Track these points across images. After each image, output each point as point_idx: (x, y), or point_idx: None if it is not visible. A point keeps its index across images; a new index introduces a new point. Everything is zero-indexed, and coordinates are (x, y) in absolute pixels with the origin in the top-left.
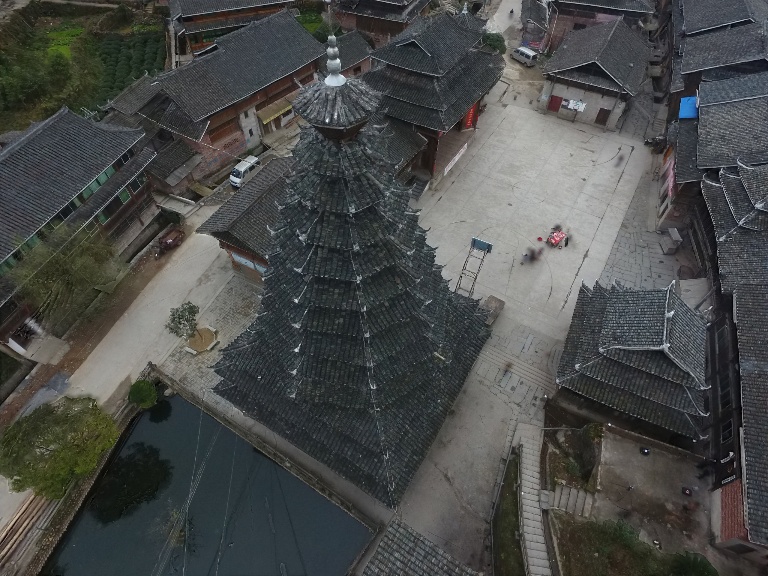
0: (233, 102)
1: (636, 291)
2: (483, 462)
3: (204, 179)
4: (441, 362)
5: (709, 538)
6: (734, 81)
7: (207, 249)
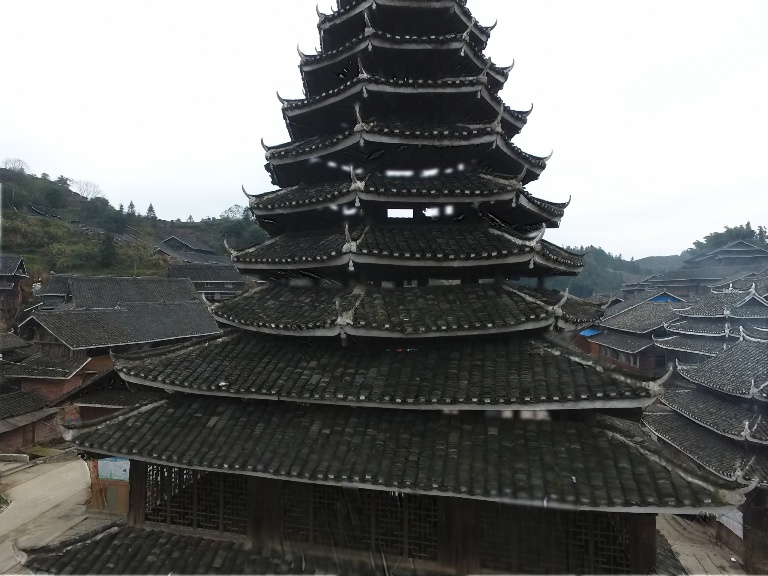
0: (129, 343)
1: (712, 358)
2: None
3: (51, 445)
4: (595, 308)
5: None
6: (609, 309)
7: (34, 501)
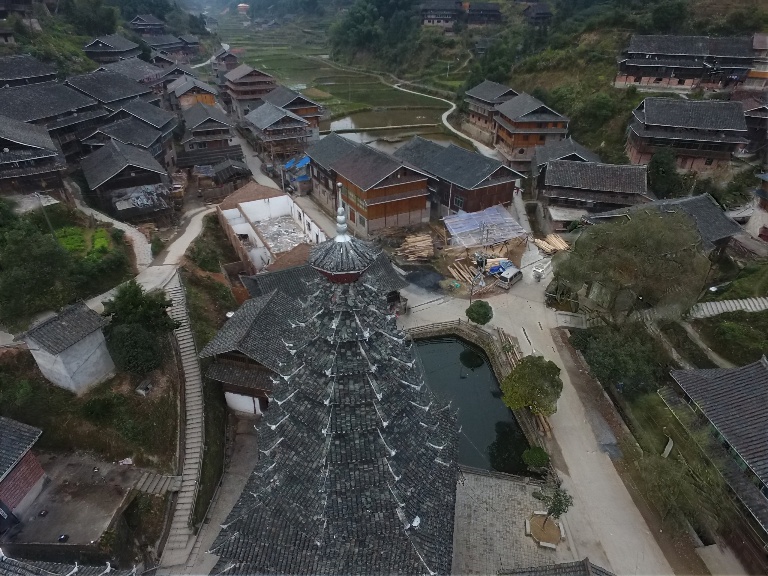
0: None
1: None
2: (227, 514)
3: None
4: None
5: (48, 484)
6: None
7: None
